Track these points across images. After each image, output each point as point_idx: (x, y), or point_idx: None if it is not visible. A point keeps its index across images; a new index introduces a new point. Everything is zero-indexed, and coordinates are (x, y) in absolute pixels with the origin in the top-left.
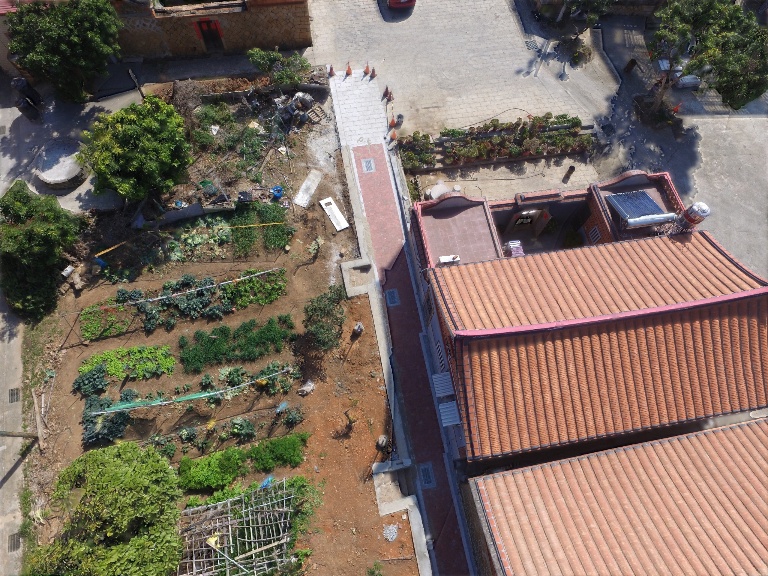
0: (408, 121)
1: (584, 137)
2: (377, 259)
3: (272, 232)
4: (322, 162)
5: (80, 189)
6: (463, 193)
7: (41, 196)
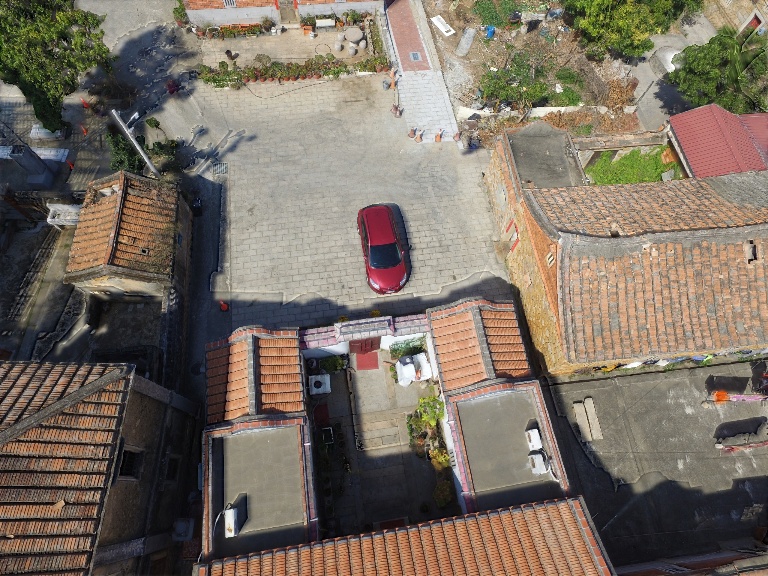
0: (378, 89)
1: (206, 70)
2: (408, 3)
3: (489, 6)
4: (457, 63)
5: (650, 54)
6: (332, 50)
7: (665, 2)
